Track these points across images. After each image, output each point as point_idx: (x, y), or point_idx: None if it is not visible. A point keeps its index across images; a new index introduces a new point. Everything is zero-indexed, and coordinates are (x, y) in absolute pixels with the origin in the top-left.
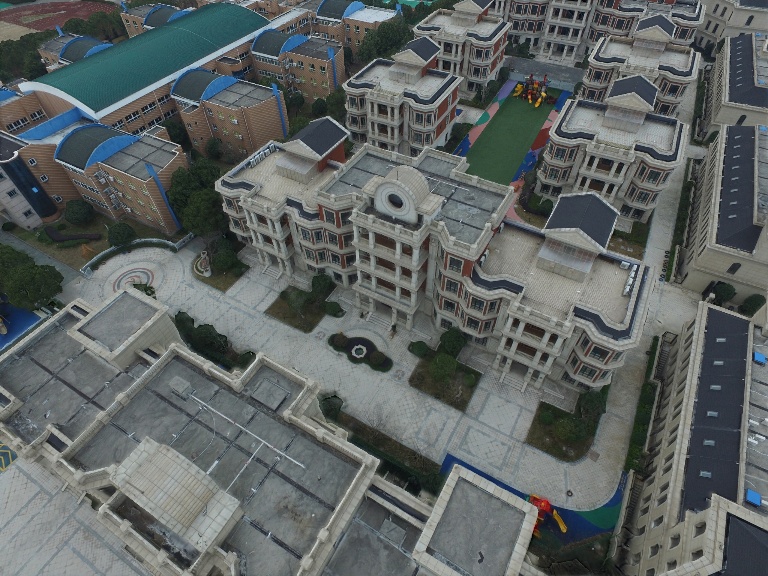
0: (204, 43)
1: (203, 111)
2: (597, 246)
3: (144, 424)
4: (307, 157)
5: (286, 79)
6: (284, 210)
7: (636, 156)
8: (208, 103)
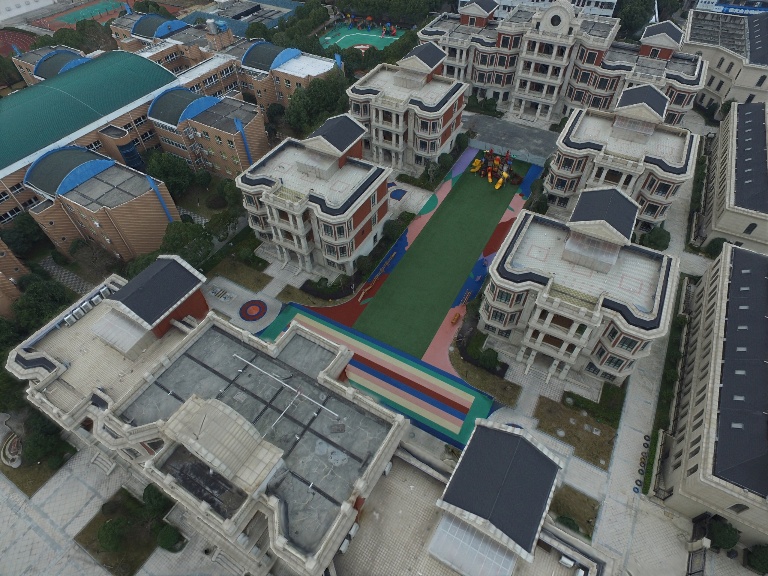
0: (82, 110)
1: (61, 207)
2: (517, 552)
3: None
4: (136, 321)
5: (192, 150)
6: (86, 413)
7: (604, 316)
8: (64, 199)
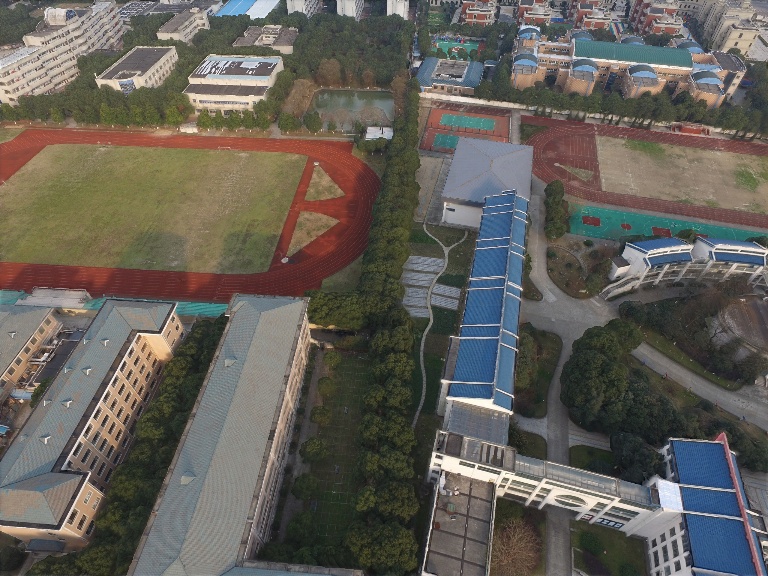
0: None
1: None
2: None
3: None
4: None
5: None
6: None
7: None
8: None
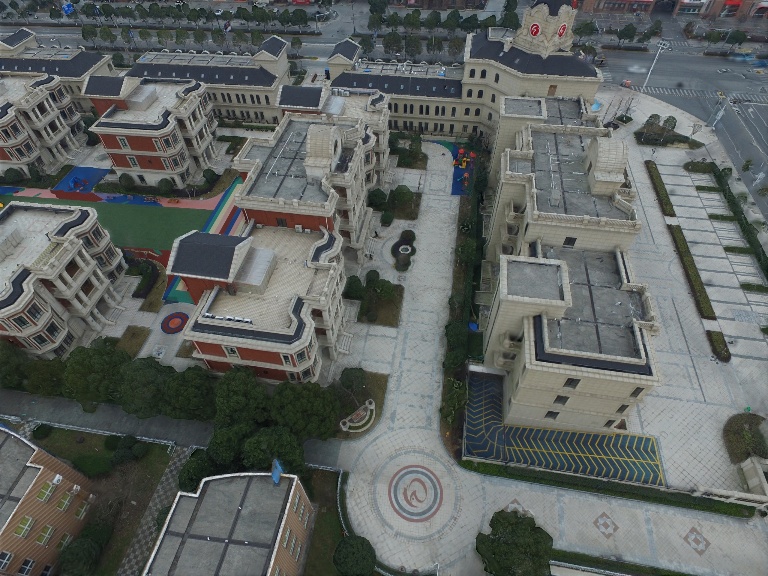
0: None
1: None
2: None
3: (586, 208)
4: (245, 256)
5: None
6: None
7: None
8: None
